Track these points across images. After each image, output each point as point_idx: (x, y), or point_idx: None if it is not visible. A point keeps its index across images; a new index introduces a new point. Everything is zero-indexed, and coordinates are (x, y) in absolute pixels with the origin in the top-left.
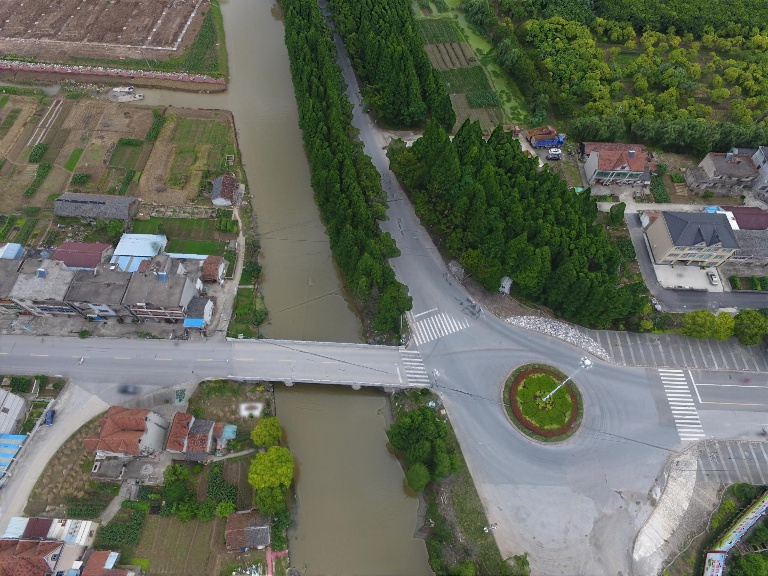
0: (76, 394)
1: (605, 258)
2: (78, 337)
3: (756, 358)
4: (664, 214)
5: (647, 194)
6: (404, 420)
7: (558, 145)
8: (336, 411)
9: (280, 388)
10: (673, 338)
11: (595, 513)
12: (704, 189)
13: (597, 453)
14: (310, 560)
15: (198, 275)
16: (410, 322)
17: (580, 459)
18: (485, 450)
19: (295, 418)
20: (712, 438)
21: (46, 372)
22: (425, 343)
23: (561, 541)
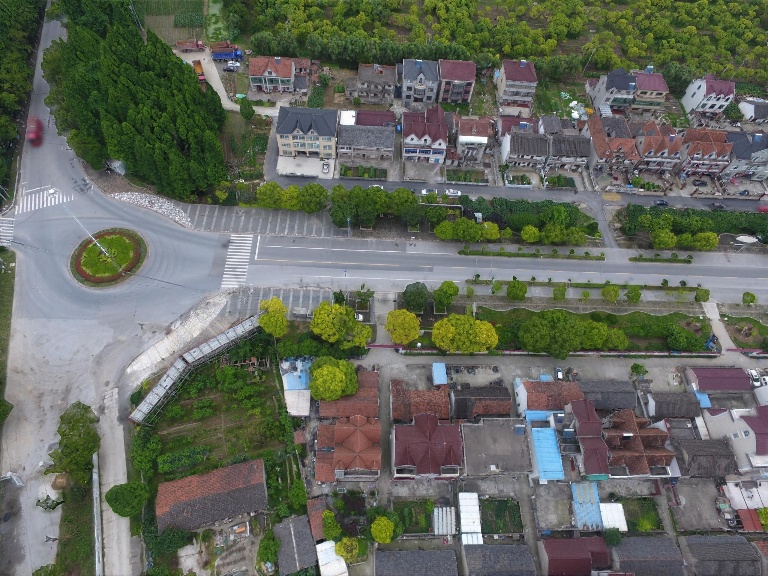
0: None
1: (198, 139)
2: None
3: (326, 227)
4: (280, 108)
5: (304, 101)
6: None
7: (238, 59)
8: None
9: None
10: (258, 211)
11: (110, 339)
12: (358, 98)
13: (138, 296)
14: None
15: None
16: (18, 196)
17: (119, 300)
18: (35, 293)
19: None
20: (250, 285)
21: None
22: (24, 212)
23: (67, 359)
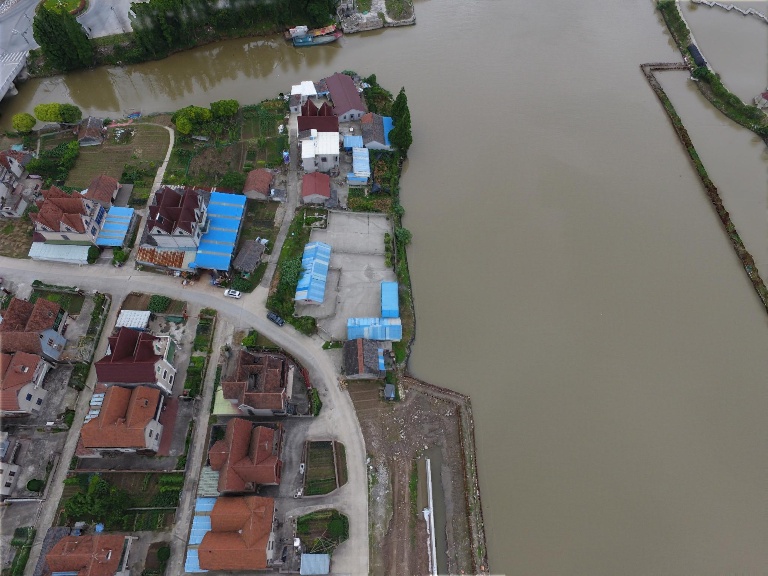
0: None
1: None
2: None
3: None
4: None
5: None
6: (34, 29)
7: None
8: None
9: None
10: None
11: None
12: None
13: None
14: None
15: None
16: None
17: None
18: None
19: None
20: None
21: None
22: None
23: None
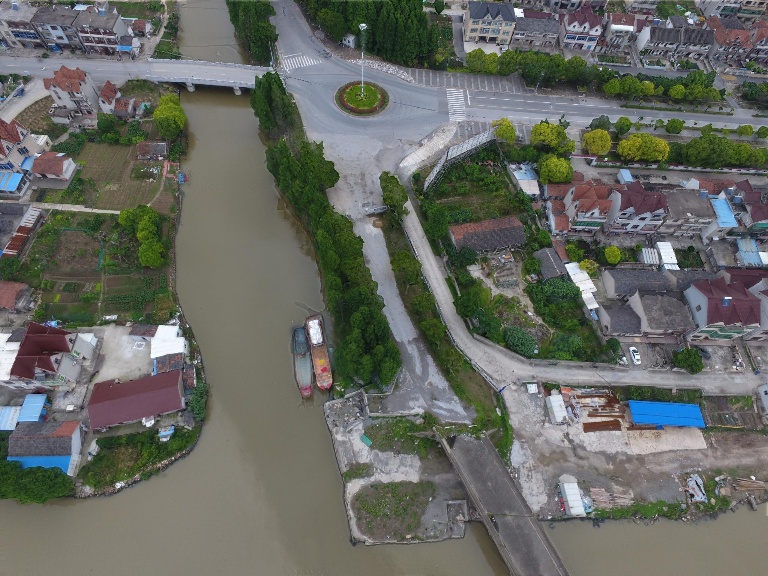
0: (39, 84)
1: (417, 18)
2: (41, 57)
3: (515, 87)
4: (469, 2)
5: None
6: None
7: None
8: (225, 115)
9: (185, 93)
10: (462, 75)
11: (381, 147)
12: None
13: (391, 123)
14: (194, 170)
15: (130, 27)
16: (280, 59)
17: (379, 125)
18: (317, 118)
19: (195, 115)
20: (471, 120)
21: (18, 73)
22: None
23: (355, 157)
